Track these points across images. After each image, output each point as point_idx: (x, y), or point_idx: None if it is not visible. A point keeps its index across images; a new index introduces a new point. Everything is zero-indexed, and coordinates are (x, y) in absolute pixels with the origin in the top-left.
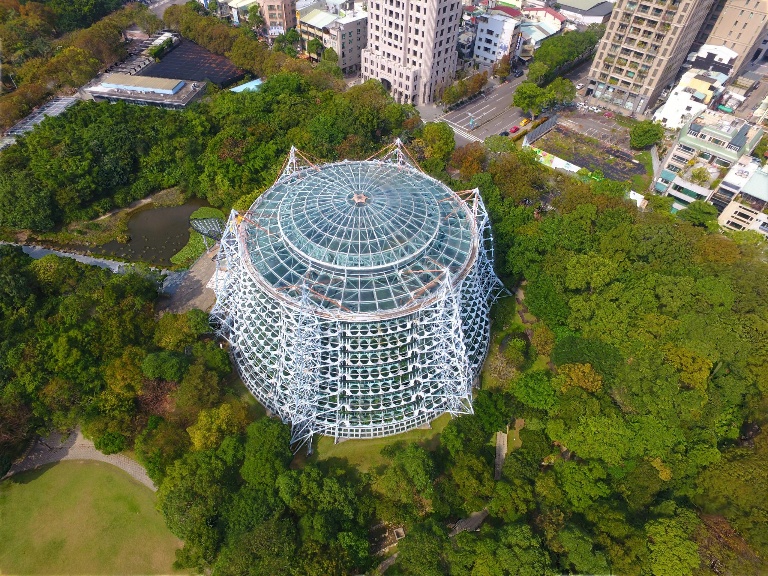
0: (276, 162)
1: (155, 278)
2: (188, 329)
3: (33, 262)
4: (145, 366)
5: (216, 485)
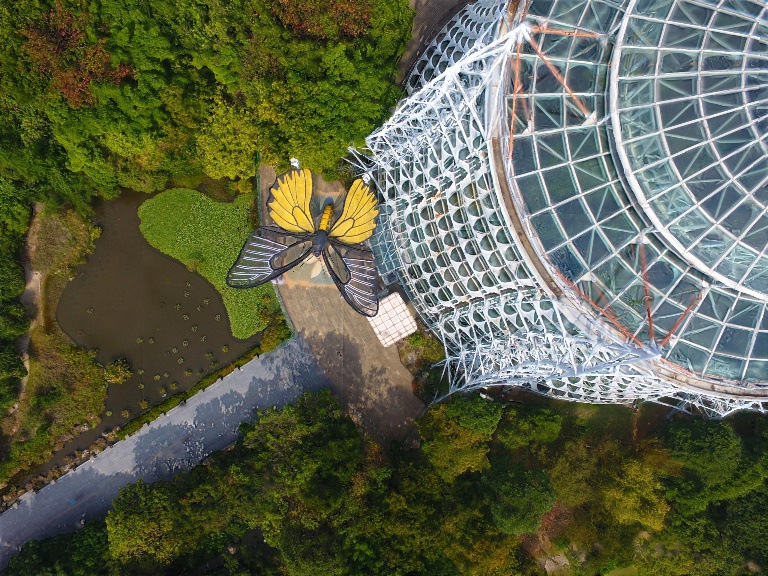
0: (174, 8)
1: (334, 418)
2: (480, 436)
3: (114, 554)
4: (517, 532)
5: (725, 541)
